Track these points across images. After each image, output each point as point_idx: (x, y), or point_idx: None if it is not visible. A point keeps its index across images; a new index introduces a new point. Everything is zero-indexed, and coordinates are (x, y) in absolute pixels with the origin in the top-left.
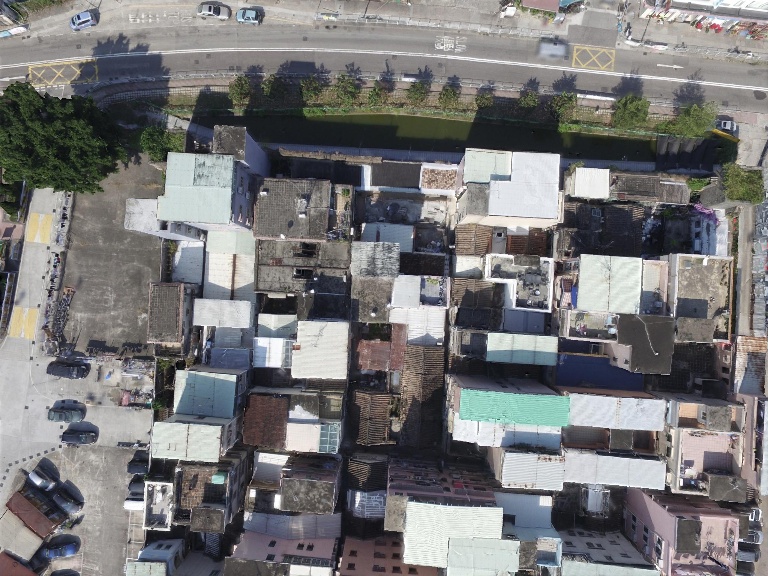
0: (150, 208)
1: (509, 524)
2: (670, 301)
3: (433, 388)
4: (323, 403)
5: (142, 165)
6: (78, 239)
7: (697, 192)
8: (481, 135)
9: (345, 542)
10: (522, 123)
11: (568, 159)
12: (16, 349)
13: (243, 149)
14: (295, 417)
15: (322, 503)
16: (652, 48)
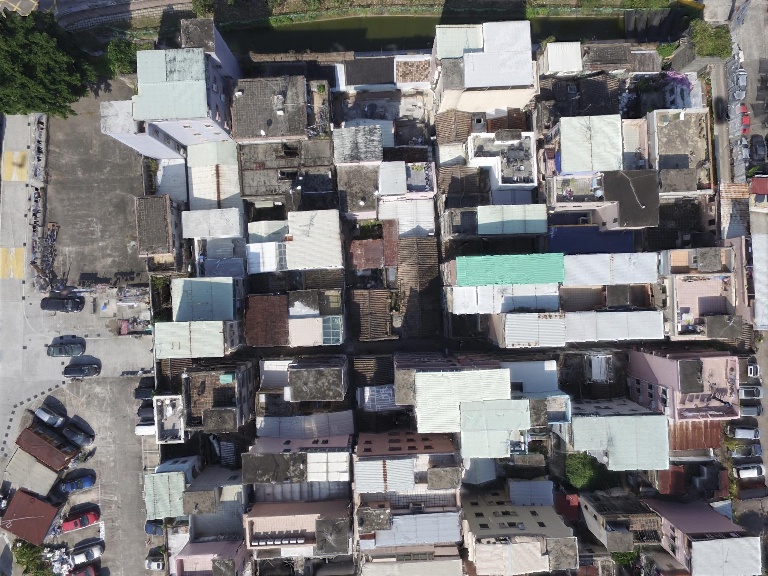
0: (125, 109)
1: (517, 391)
2: (652, 159)
3: (429, 278)
4: (322, 300)
5: (113, 92)
6: (56, 173)
7: (668, 59)
8: None
9: (359, 436)
10: (490, 12)
11: (539, 44)
12: (7, 290)
13: (213, 41)
14: (296, 314)
15: (332, 390)
16: None
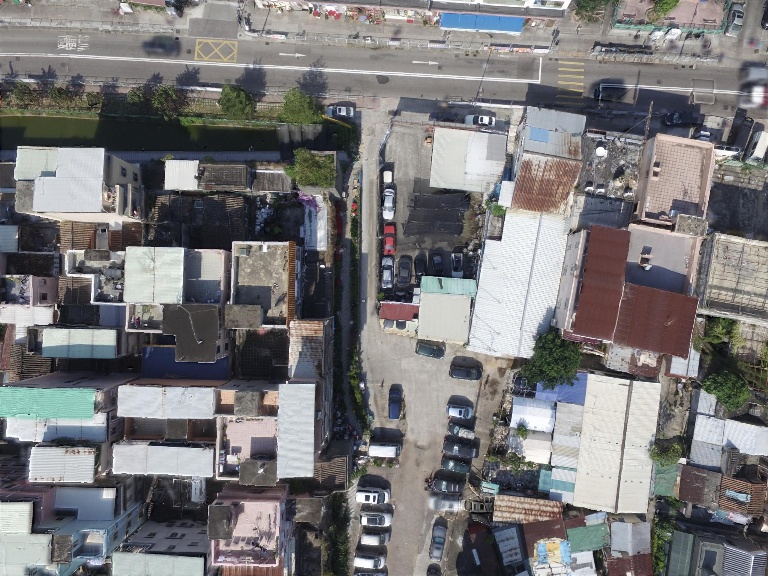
0: None
1: (70, 518)
2: None
3: None
4: None
5: None
6: None
7: None
8: (108, 132)
9: None
10: (143, 118)
11: (194, 152)
12: None
13: None
14: None
15: None
16: (272, 37)
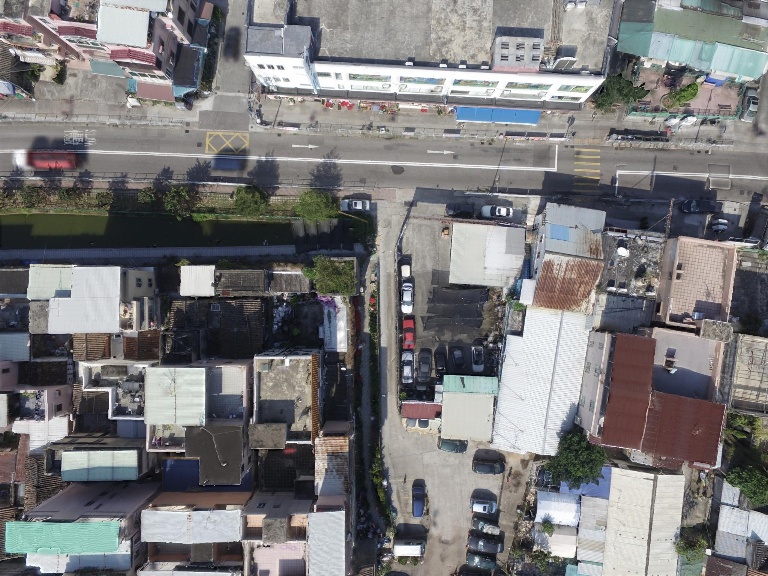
0: None
1: None
2: None
3: None
4: None
5: None
6: None
7: None
8: (118, 228)
9: None
10: (154, 215)
11: (207, 247)
12: None
13: None
14: None
15: None
16: (284, 129)
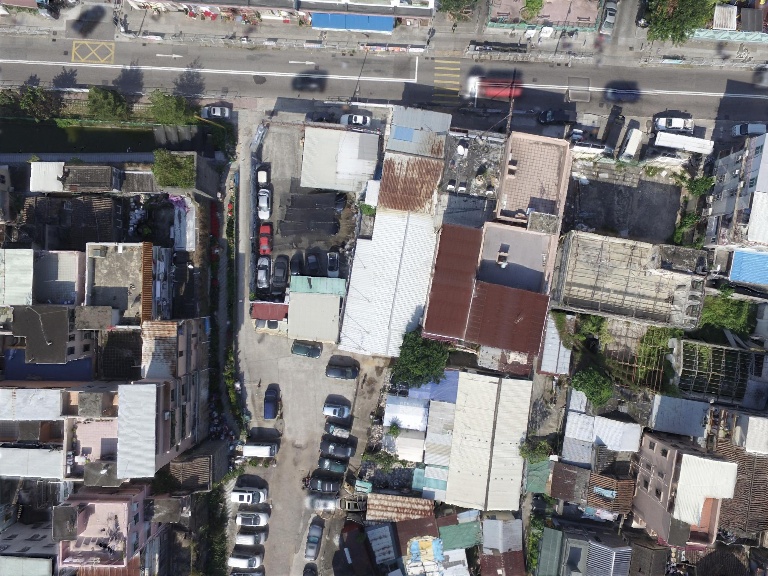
0: None
1: None
2: None
3: None
4: None
5: None
6: None
7: None
8: None
9: None
10: (19, 120)
11: (71, 154)
12: None
13: None
14: None
15: None
16: (148, 39)
